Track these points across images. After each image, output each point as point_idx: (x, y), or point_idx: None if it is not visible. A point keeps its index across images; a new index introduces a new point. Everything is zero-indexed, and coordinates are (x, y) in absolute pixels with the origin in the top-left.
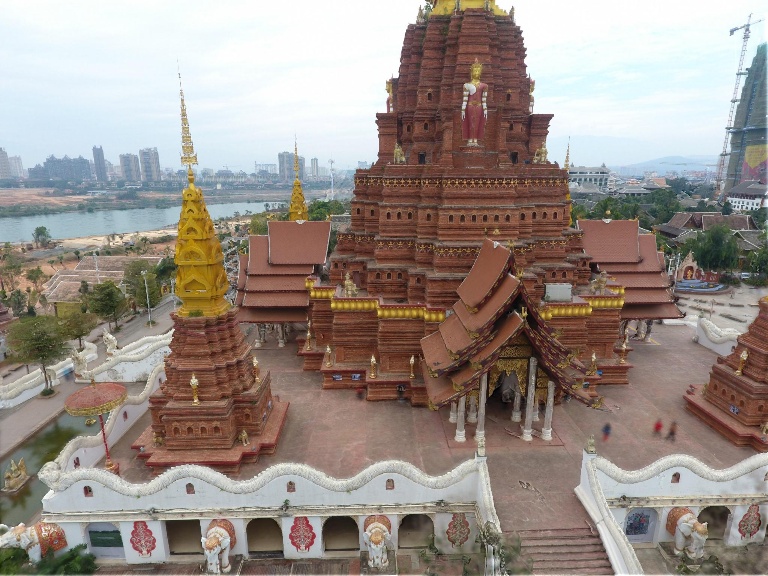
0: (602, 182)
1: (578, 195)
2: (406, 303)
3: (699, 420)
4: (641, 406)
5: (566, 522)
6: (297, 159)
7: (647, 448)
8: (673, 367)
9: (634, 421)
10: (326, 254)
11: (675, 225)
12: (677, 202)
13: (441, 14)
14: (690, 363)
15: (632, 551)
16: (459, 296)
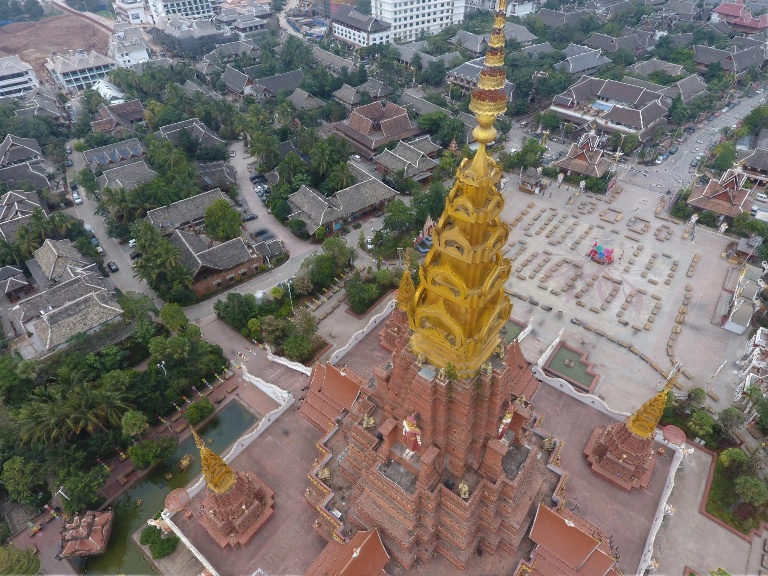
0: (203, 4)
1: (198, 41)
2: (486, 552)
3: (603, 480)
4: (580, 488)
5: None
6: None
7: (613, 529)
8: (553, 424)
9: (591, 507)
10: (385, 551)
11: (359, 130)
12: (322, 67)
13: (473, 377)
14: (553, 411)
15: None
16: (538, 544)
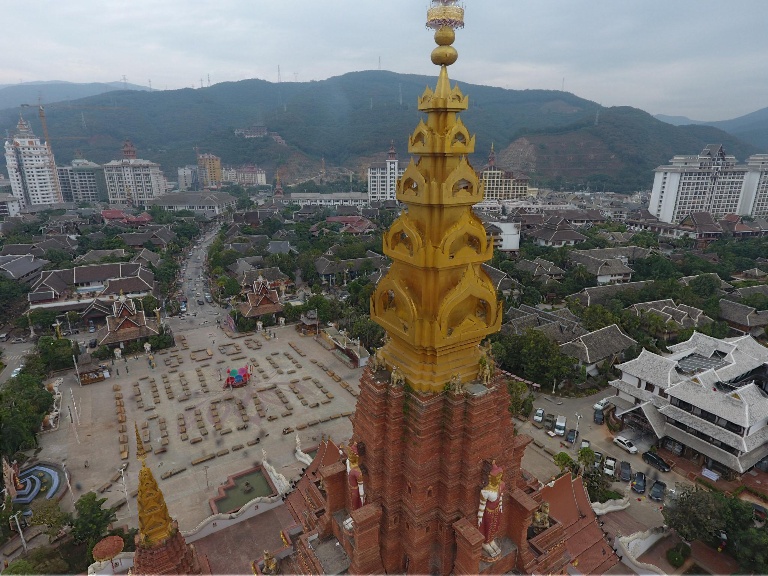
0: None
1: None
2: None
3: None
4: None
5: None
6: None
7: None
8: None
9: None
10: None
11: None
12: None
13: None
14: None
15: None
16: None
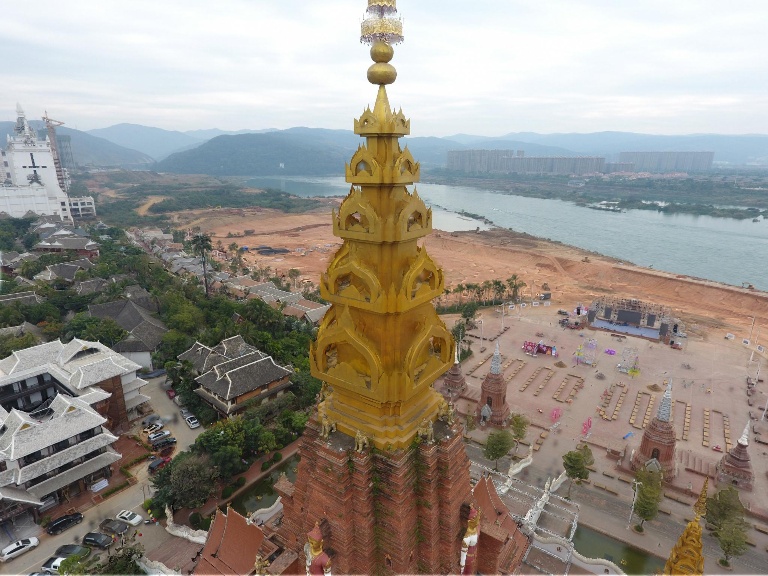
0: None
1: None
2: None
3: None
4: None
5: (186, 568)
6: (702, 498)
7: None
8: None
9: None
10: None
11: None
12: None
13: None
14: None
15: (158, 562)
16: None
